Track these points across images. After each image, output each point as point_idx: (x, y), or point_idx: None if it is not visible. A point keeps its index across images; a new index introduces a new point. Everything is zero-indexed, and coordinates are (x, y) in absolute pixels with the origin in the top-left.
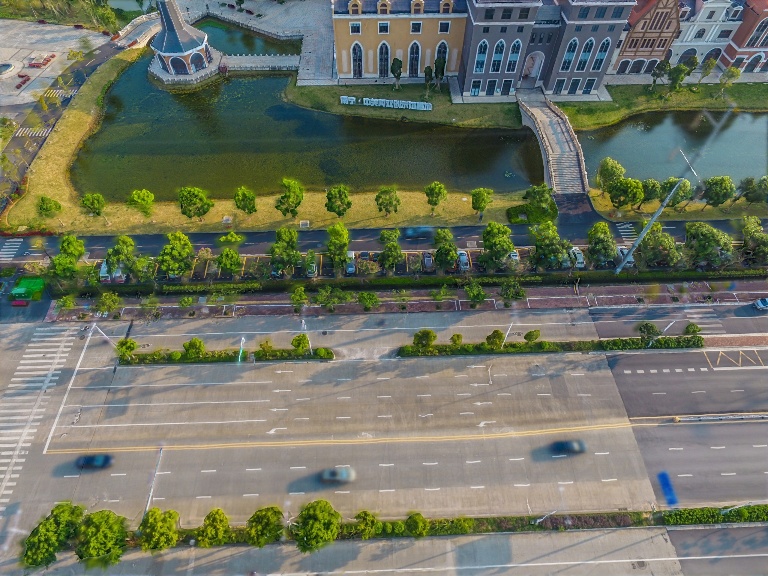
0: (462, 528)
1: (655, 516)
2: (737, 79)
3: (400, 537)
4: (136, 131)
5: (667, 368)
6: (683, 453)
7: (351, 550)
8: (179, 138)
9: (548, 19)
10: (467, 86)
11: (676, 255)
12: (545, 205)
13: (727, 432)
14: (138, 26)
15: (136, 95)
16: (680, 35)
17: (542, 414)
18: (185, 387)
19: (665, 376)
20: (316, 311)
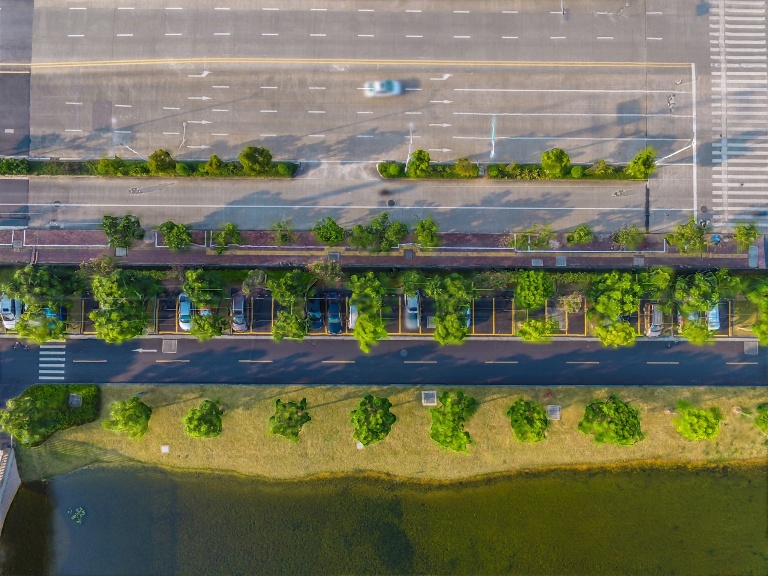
0: None
1: None
2: None
3: None
4: None
5: None
6: None
7: None
8: None
9: None
10: None
11: None
12: None
13: None
14: None
15: None
16: None
17: (132, 82)
18: (557, 135)
19: None
20: (404, 237)
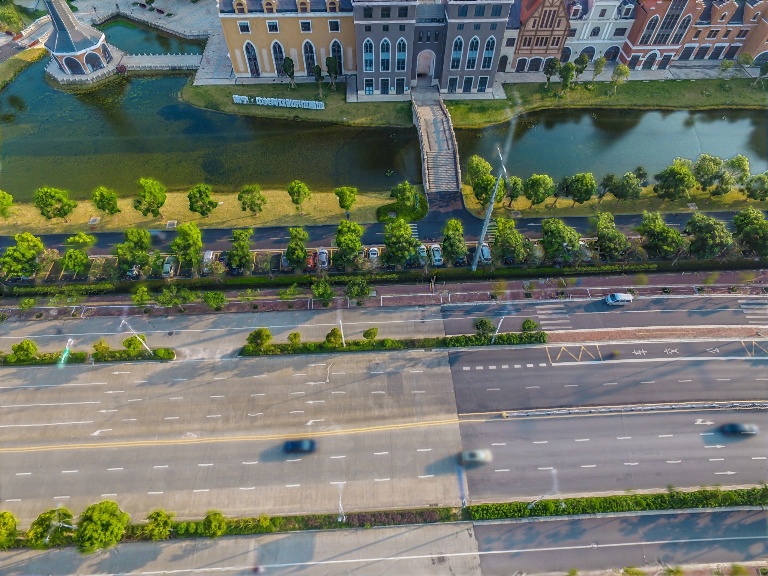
0: (267, 527)
1: (464, 511)
2: (634, 77)
3: (204, 537)
4: (22, 132)
5: (506, 364)
6: (505, 448)
7: (153, 551)
8: (65, 138)
9: (432, 17)
10: (360, 85)
11: (521, 252)
12: (410, 203)
13: (552, 427)
14: (42, 26)
15: (30, 95)
16: (576, 33)
17: (372, 411)
18: (17, 389)
19: (503, 372)
20: (166, 311)
